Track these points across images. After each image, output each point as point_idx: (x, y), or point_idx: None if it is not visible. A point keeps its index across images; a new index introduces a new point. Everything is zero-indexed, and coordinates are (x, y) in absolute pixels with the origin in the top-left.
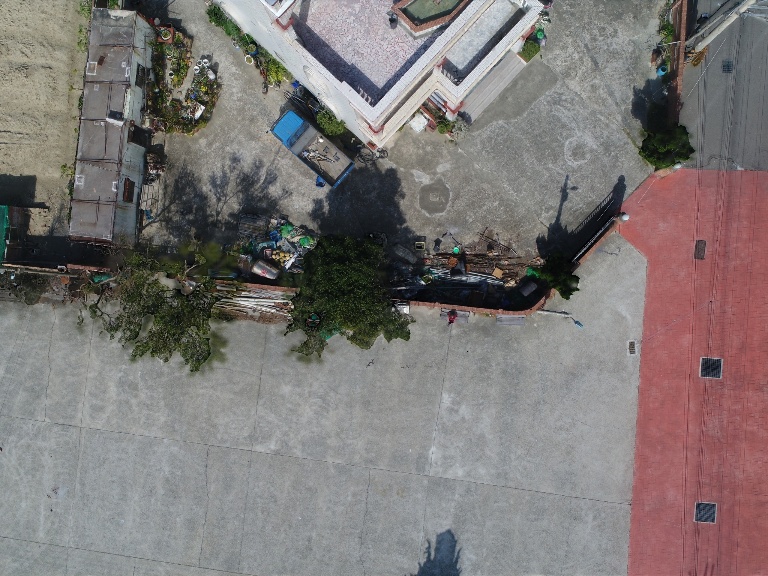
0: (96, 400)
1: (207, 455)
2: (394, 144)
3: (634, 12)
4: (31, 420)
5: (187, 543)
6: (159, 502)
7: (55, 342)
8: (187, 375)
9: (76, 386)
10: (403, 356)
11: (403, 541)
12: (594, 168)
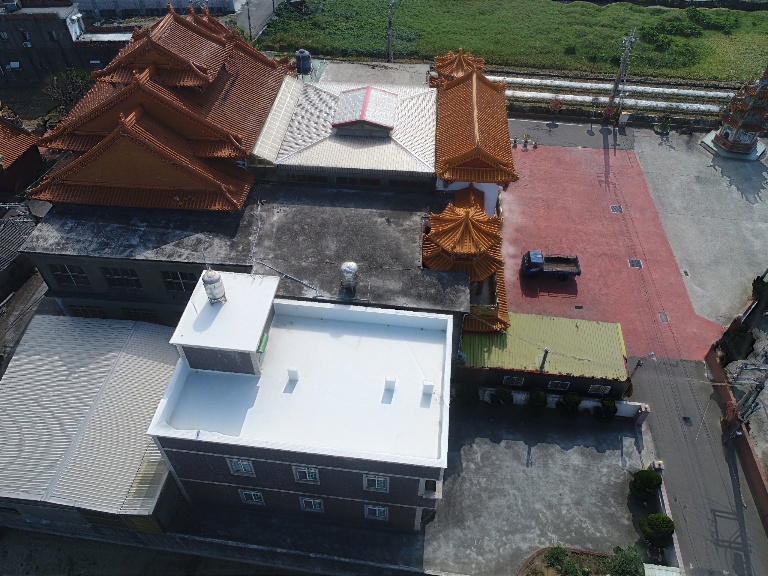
0: None
1: None
2: None
3: None
4: None
5: None
6: None
7: None
8: None
9: None
10: None
11: None
12: None
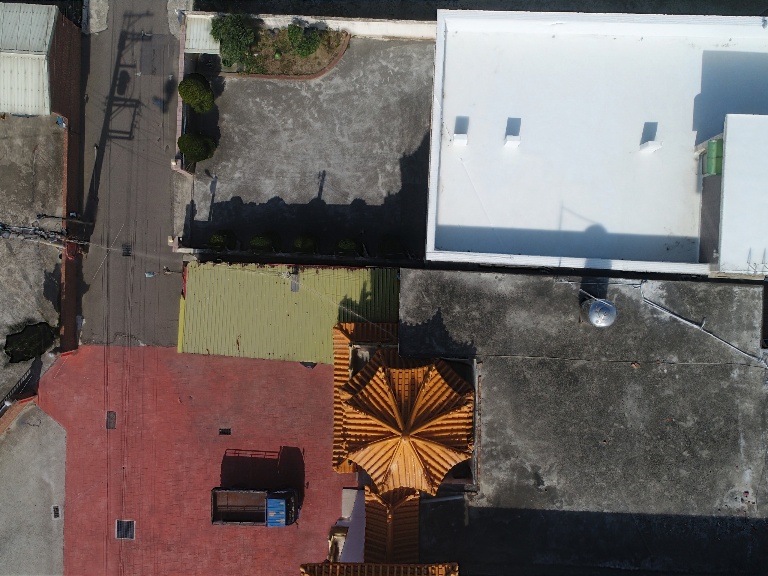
0: None
1: None
2: None
3: (42, 201)
4: None
5: None
6: None
7: None
8: None
9: None
10: None
11: None
12: None
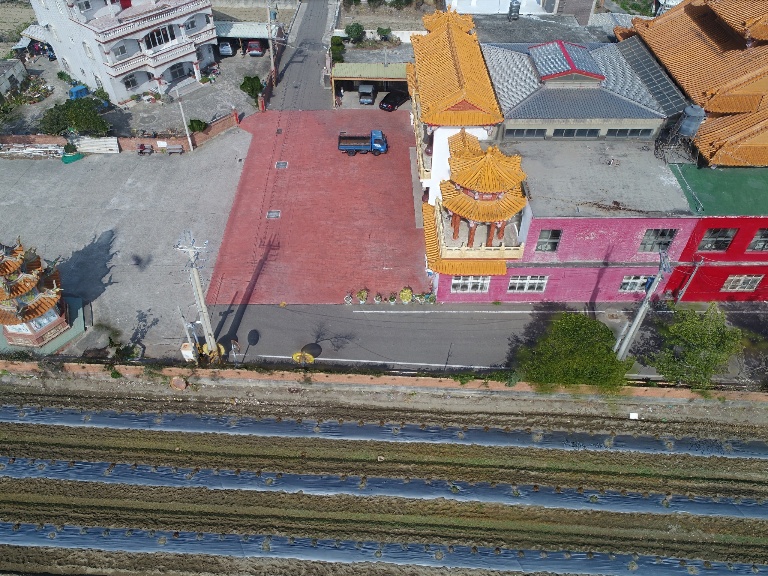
0: None
1: None
2: (133, 106)
3: None
4: None
5: None
6: None
7: None
8: None
9: None
10: (110, 167)
11: (78, 236)
12: (230, 111)
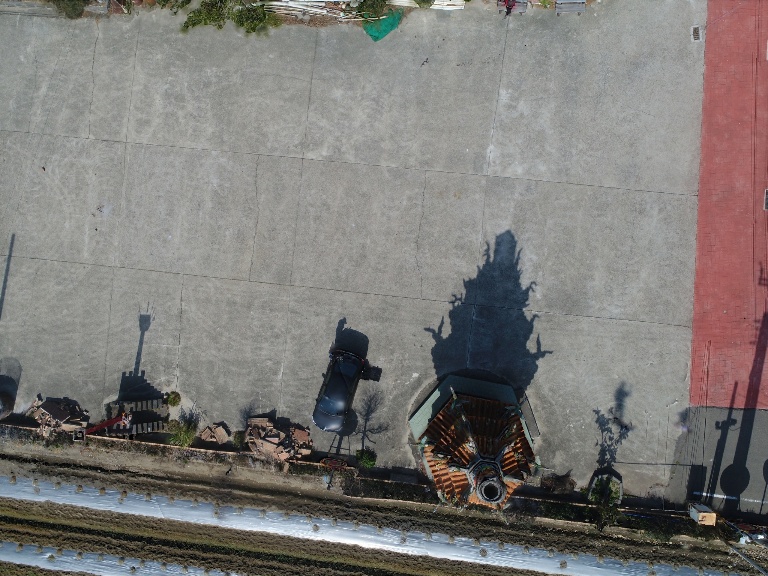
0: (141, 114)
1: (257, 165)
2: None
3: None
4: (75, 137)
5: (237, 257)
6: (207, 216)
7: (99, 57)
8: (235, 84)
9: (121, 101)
10: (459, 53)
11: (461, 244)
12: None
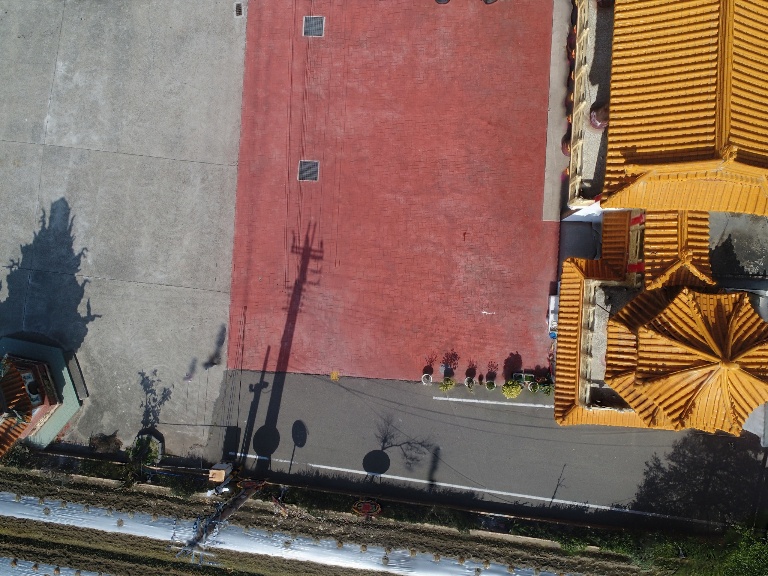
0: None
1: None
2: None
3: None
4: None
5: None
6: None
7: None
8: None
9: None
10: (19, 26)
11: (19, 211)
12: None
